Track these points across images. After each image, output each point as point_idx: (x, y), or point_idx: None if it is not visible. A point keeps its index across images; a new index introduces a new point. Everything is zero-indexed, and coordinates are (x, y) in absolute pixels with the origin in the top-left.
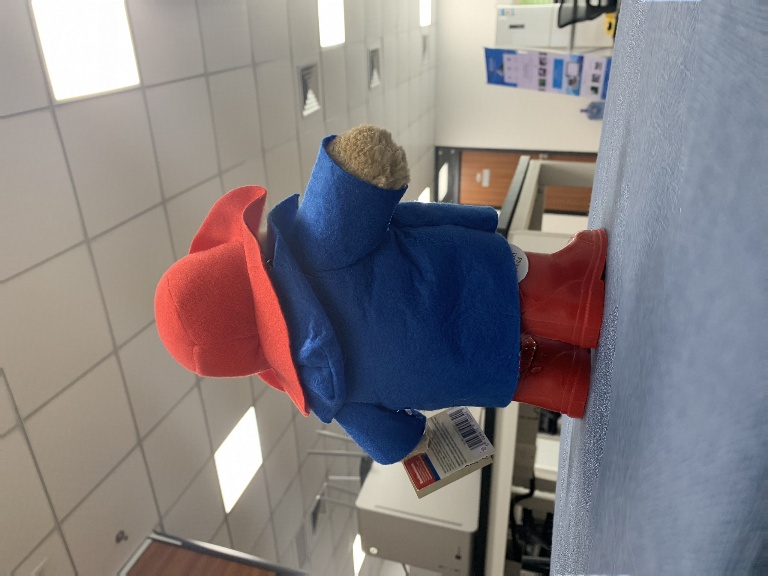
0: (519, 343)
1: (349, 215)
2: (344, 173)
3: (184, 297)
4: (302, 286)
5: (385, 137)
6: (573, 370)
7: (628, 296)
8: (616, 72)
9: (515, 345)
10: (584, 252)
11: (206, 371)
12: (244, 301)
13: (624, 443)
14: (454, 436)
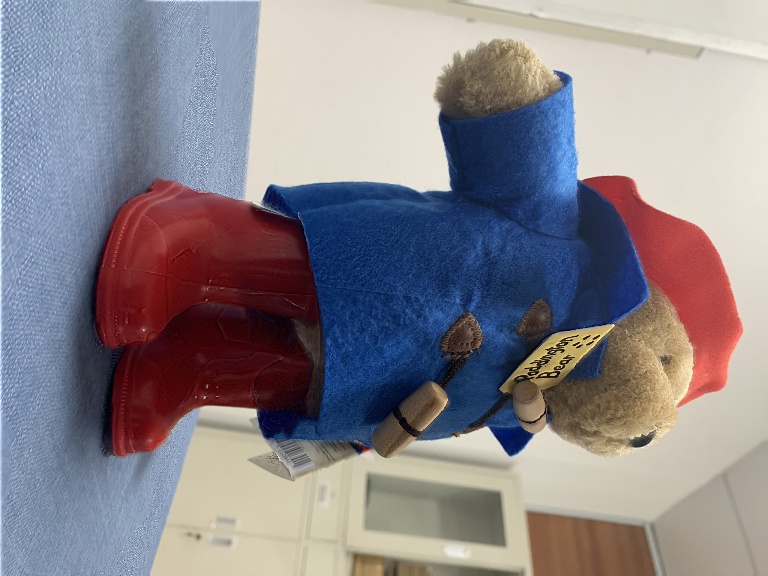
0: None
1: None
2: None
3: None
4: None
5: (486, 48)
6: None
7: None
8: None
9: None
10: (163, 211)
11: None
12: None
13: None
14: None
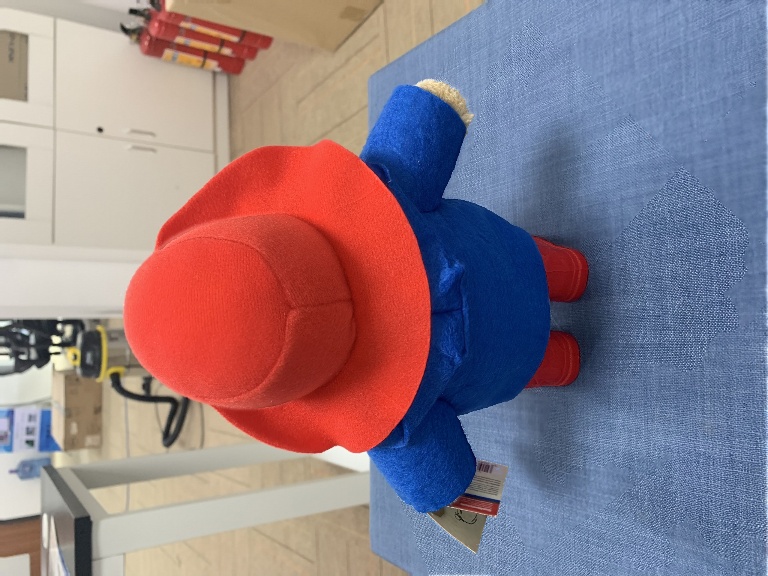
0: (548, 291)
1: (444, 148)
2: (445, 103)
3: (267, 241)
4: (420, 214)
5: None
6: (557, 335)
7: (733, 117)
8: None
9: (546, 294)
10: None
11: (289, 366)
12: (331, 255)
13: None
14: None
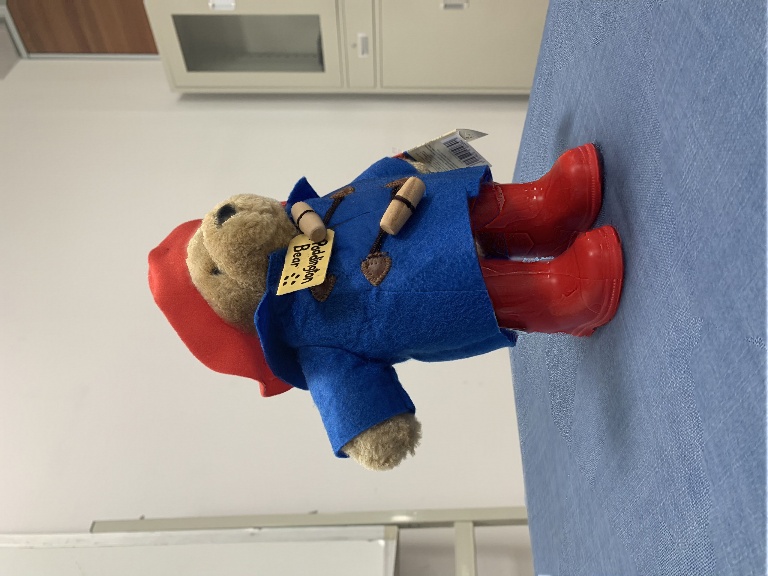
0: None
1: None
2: None
3: None
4: None
5: None
6: None
7: None
8: None
9: None
10: None
11: None
12: None
13: None
14: (451, 159)
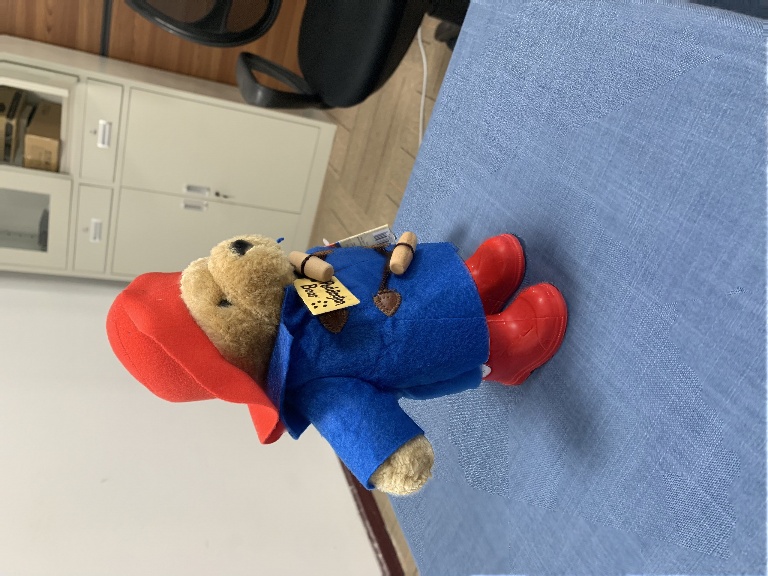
0: None
1: None
2: None
3: None
4: None
5: None
6: None
7: (506, 546)
8: (759, 180)
9: None
10: None
11: None
12: None
13: (469, 573)
14: None
